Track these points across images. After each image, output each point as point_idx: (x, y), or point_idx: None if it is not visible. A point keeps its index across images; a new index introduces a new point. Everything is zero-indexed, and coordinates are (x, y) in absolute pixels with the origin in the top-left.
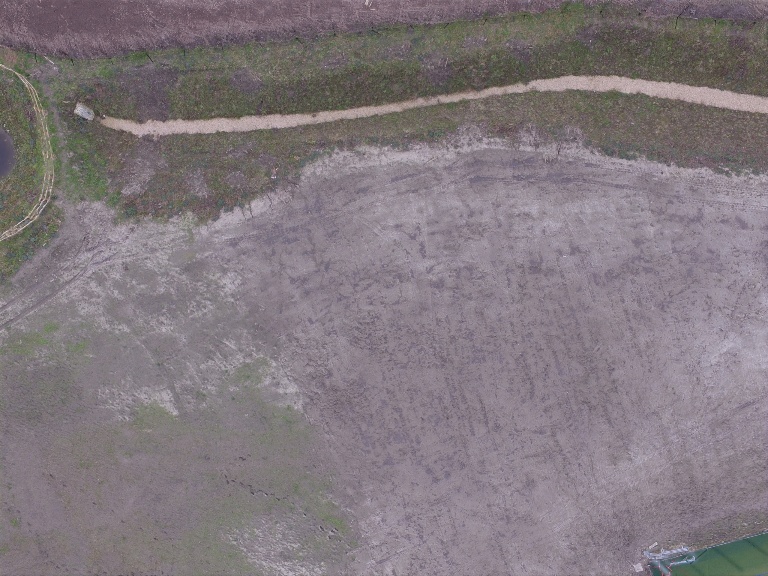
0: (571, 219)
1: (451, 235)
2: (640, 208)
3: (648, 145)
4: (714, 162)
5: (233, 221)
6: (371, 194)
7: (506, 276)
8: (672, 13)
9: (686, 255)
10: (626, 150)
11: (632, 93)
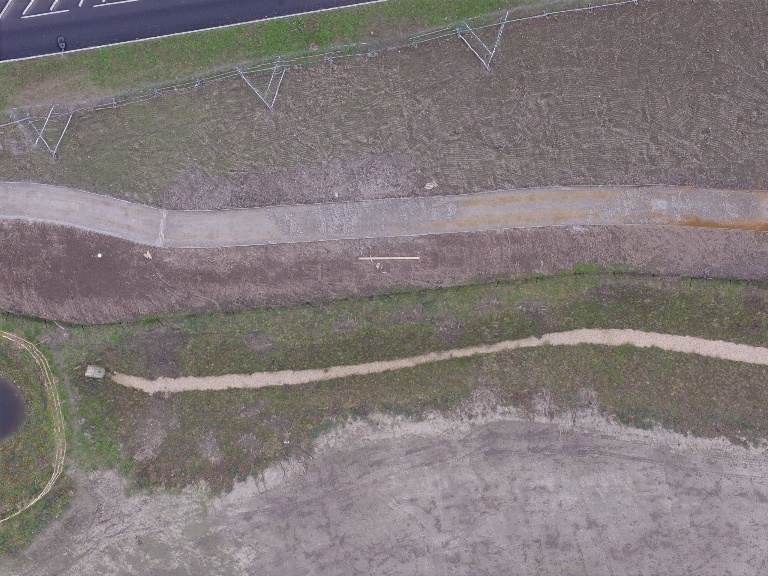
0: (587, 492)
1: (466, 509)
2: (657, 481)
3: (664, 410)
4: (731, 430)
5: (246, 494)
6: (385, 467)
7: (523, 551)
8: (686, 273)
9: (704, 529)
10: (642, 417)
11: (646, 347)
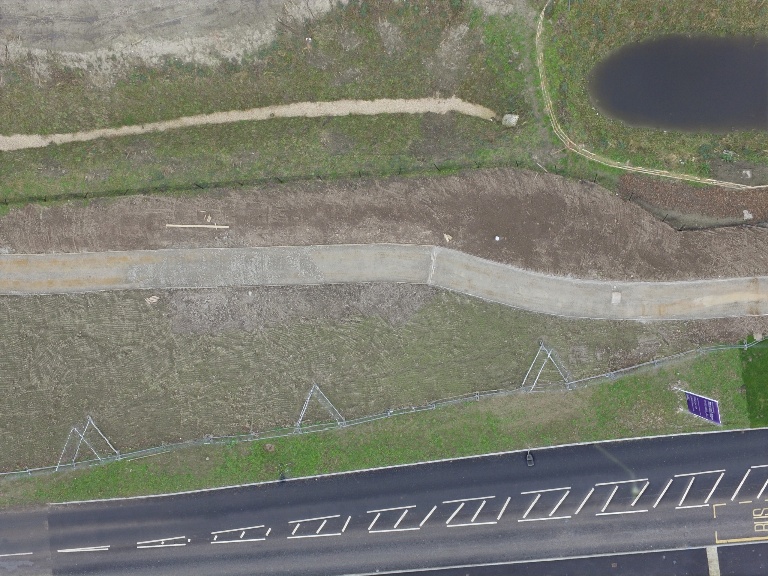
0: None
1: None
2: None
3: None
4: None
5: None
6: (202, 8)
7: None
8: None
9: None
10: None
11: None
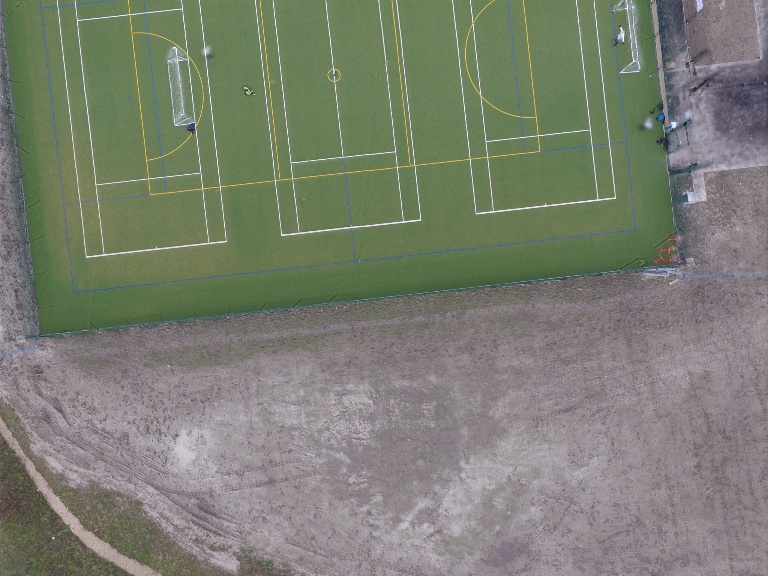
0: None
1: None
2: None
3: None
4: None
5: None
6: None
7: None
8: None
9: (606, 569)
10: None
11: None
